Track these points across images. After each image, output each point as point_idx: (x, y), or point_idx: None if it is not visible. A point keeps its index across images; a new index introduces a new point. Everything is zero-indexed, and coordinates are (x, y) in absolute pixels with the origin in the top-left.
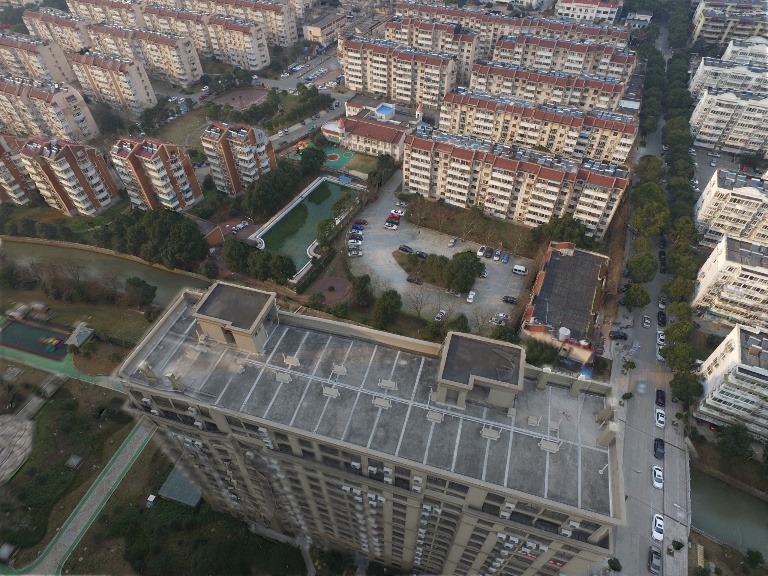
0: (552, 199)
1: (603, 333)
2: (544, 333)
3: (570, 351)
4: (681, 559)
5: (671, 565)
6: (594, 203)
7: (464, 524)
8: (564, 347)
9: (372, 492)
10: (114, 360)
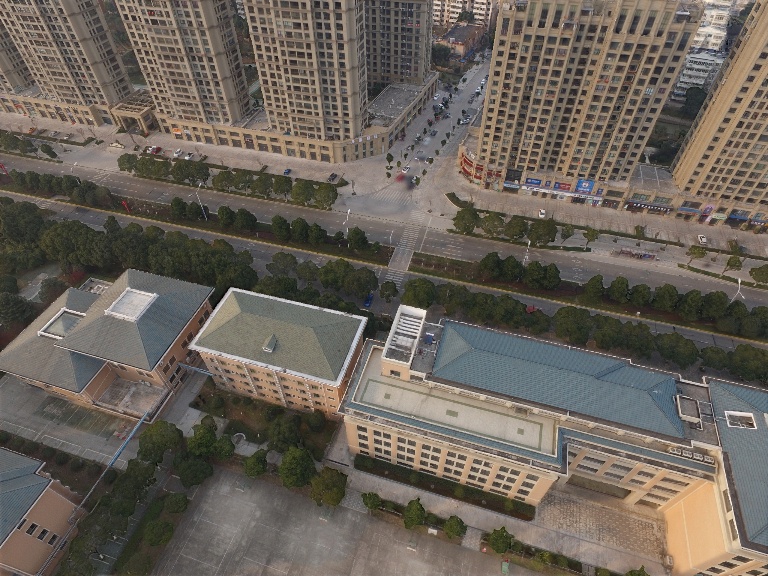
0: (460, 6)
1: (476, 54)
2: (444, 41)
3: (455, 48)
4: (484, 95)
5: (480, 96)
6: (481, 7)
7: (392, 12)
8: (452, 47)
9: (366, 5)
10: (250, 59)
